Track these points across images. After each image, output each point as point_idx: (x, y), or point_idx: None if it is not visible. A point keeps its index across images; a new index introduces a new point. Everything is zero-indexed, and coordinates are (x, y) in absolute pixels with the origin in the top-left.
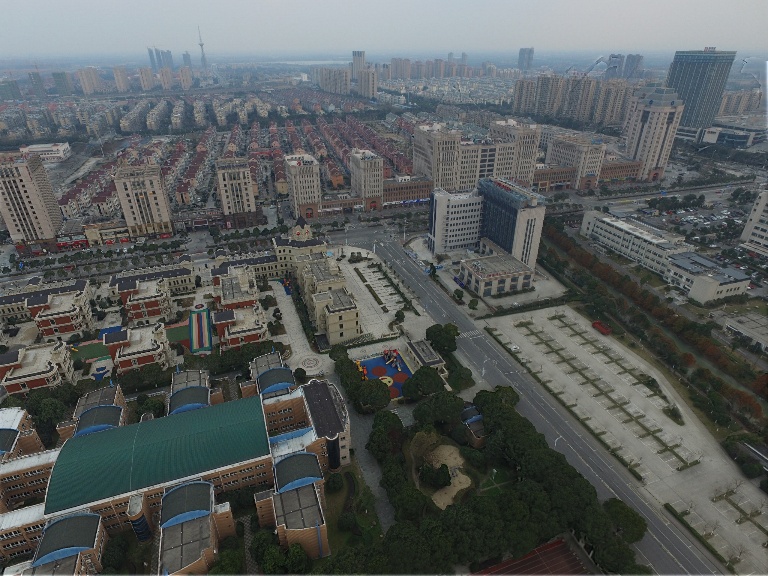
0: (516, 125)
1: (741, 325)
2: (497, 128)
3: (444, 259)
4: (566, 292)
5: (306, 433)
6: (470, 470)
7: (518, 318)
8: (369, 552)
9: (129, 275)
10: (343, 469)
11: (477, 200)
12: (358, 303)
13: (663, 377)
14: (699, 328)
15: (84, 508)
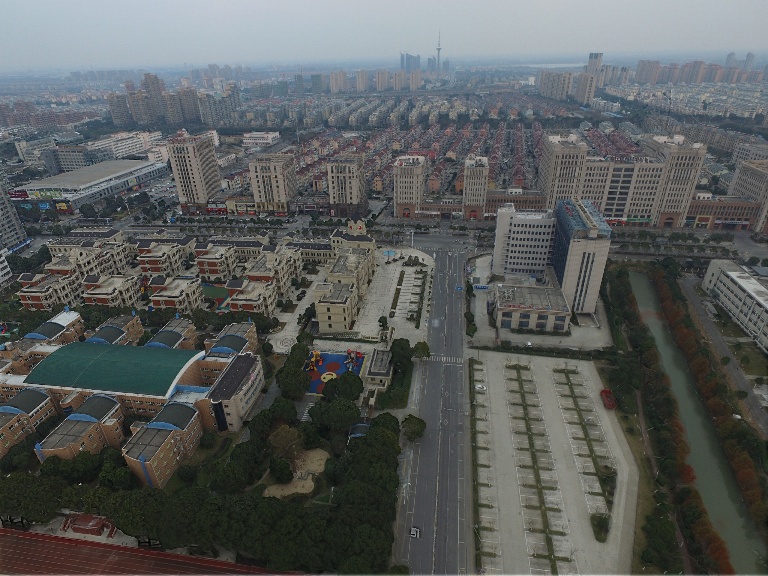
0: (682, 143)
1: None
2: (652, 144)
3: (496, 280)
4: (606, 348)
5: (206, 391)
6: (321, 480)
7: None
8: (159, 498)
9: (218, 239)
10: (228, 434)
11: (547, 222)
12: (374, 303)
13: (636, 480)
14: (745, 440)
15: (45, 388)
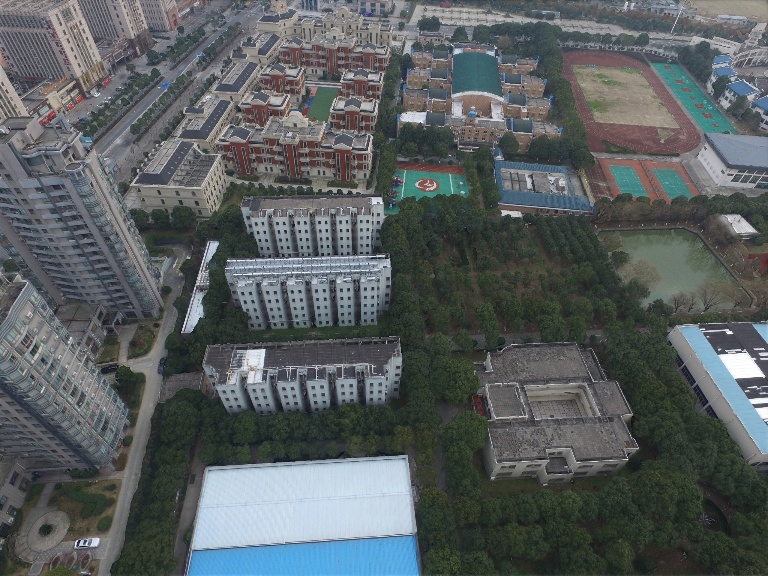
0: None
1: None
2: None
3: None
4: (406, 1)
5: None
6: None
7: (417, 16)
8: None
9: (233, 79)
10: None
11: None
12: None
13: None
14: None
15: None
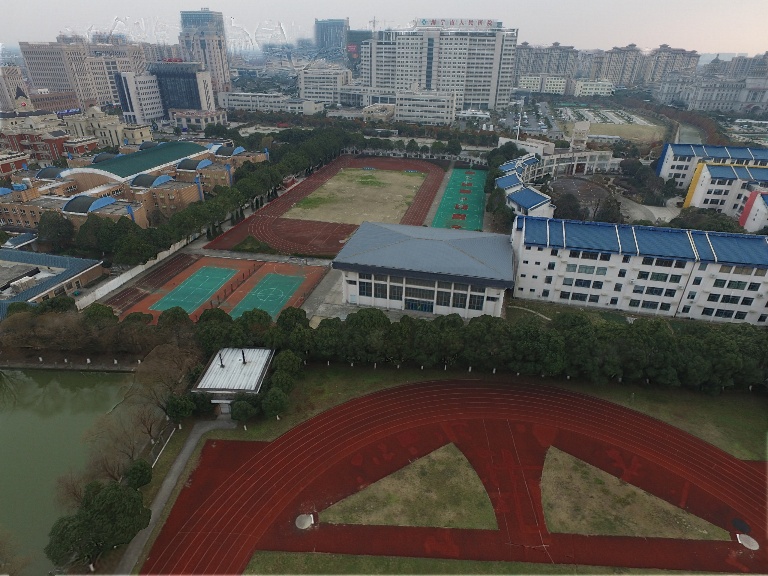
0: None
1: (334, 112)
2: (100, 49)
3: None
4: None
5: (212, 147)
6: None
7: None
8: None
9: None
10: None
11: (153, 78)
12: None
13: None
14: (322, 115)
15: None
